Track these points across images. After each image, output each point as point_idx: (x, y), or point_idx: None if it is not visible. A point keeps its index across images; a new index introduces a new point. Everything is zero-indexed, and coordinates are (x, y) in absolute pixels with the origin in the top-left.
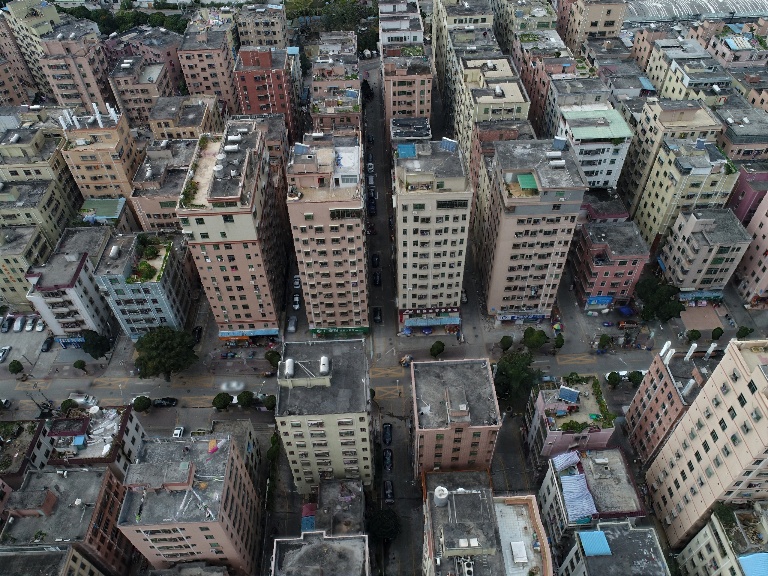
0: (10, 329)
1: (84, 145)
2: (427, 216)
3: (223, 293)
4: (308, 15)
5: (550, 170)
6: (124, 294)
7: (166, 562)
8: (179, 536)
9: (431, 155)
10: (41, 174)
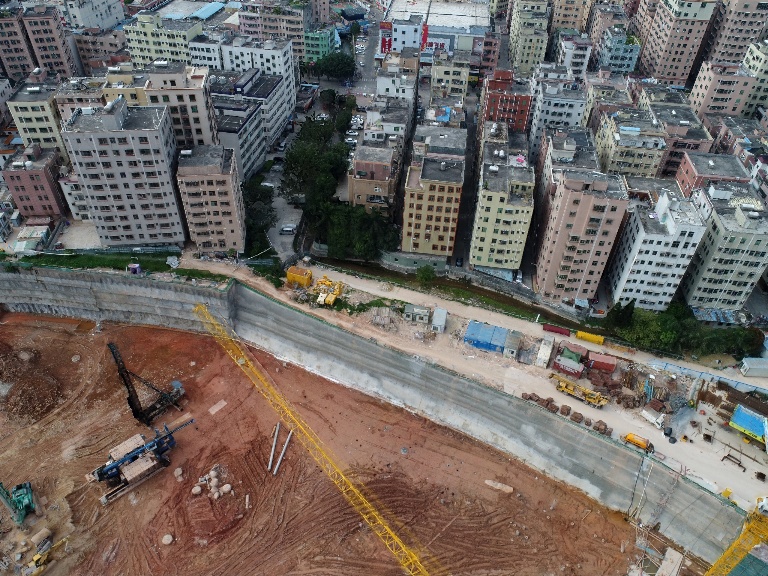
0: None
1: None
2: None
3: (671, 55)
4: None
5: None
6: (618, 52)
7: None
8: (731, 89)
9: None
10: (539, 9)
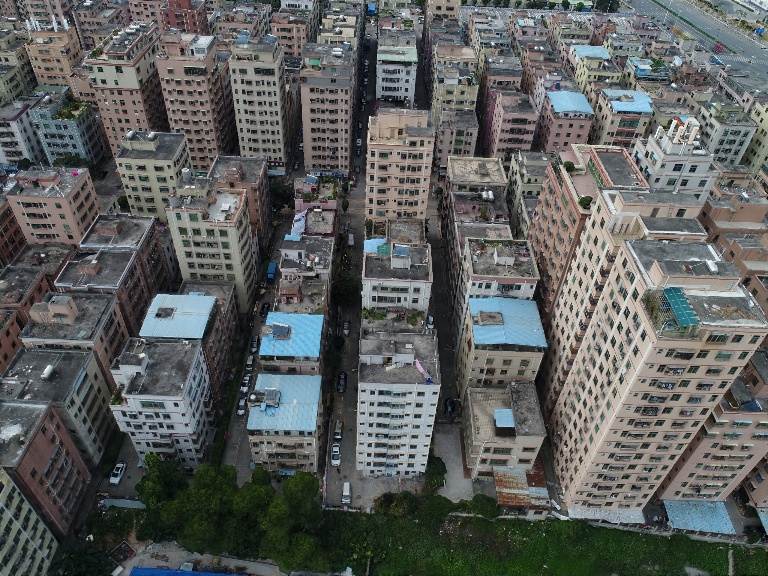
0: None
1: (42, 43)
2: (249, 80)
3: (118, 133)
4: None
5: (332, 58)
6: (50, 129)
7: None
8: (44, 213)
9: (257, 43)
10: (9, 62)
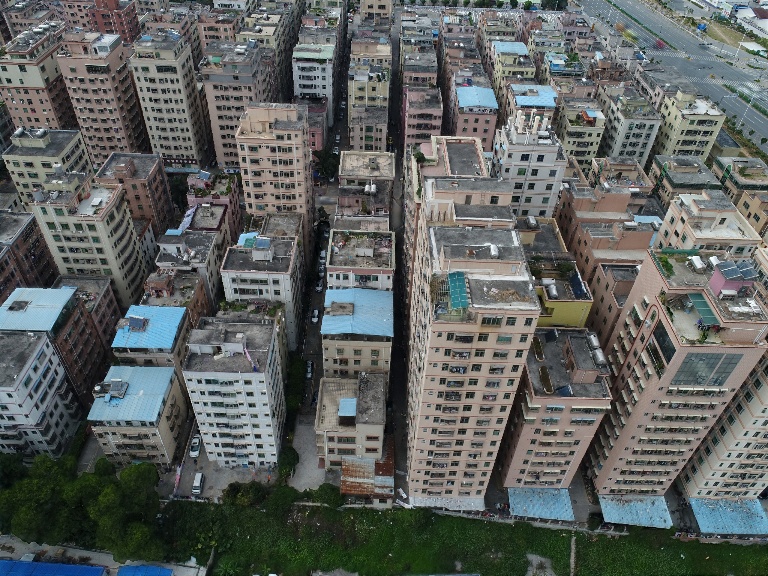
0: None
1: None
2: (152, 77)
3: None
4: (195, 0)
5: (235, 55)
6: None
7: None
8: None
9: (162, 41)
10: None
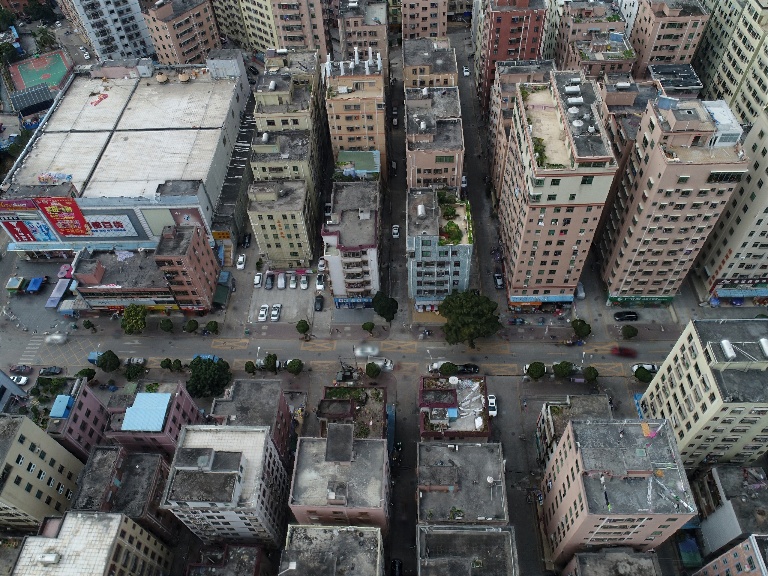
0: (273, 286)
1: (346, 93)
2: None
3: (537, 258)
4: None
5: None
6: (429, 256)
7: (582, 544)
8: (635, 524)
9: None
10: (298, 124)
